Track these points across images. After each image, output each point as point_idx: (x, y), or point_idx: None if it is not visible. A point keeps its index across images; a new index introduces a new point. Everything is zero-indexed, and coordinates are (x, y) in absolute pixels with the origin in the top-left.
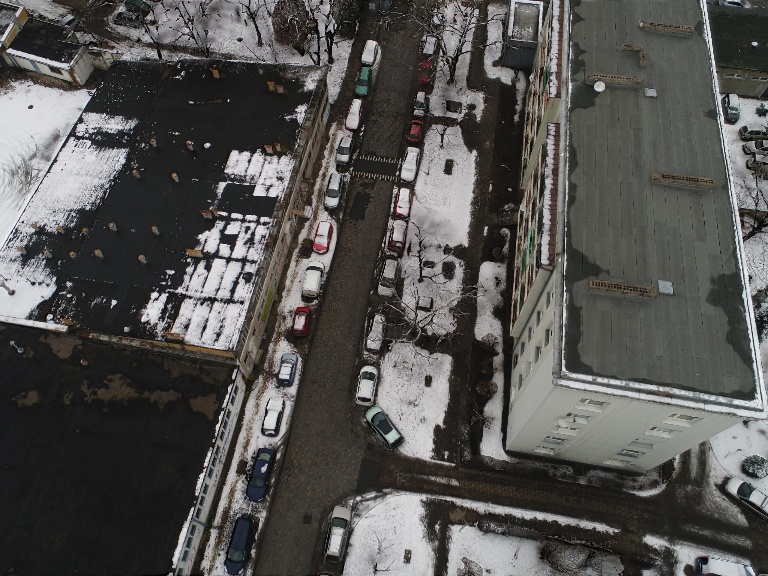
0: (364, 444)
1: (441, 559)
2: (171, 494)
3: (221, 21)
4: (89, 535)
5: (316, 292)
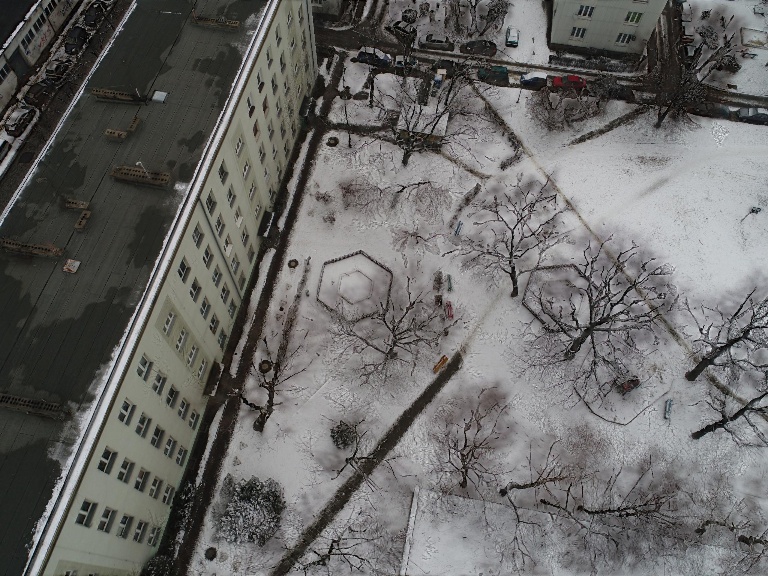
0: None
1: None
2: None
3: None
4: None
5: None
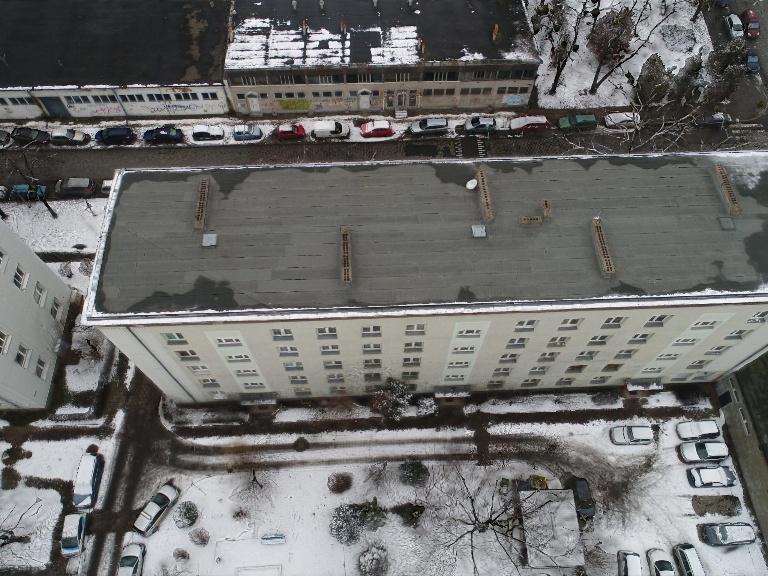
0: None
1: None
2: (127, 74)
3: (607, 5)
4: (100, 43)
5: (315, 132)
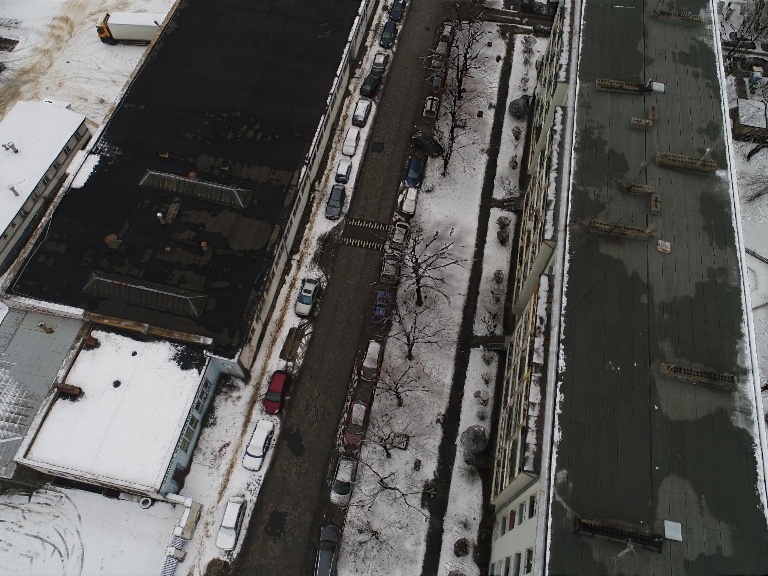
0: (460, 2)
1: (510, 46)
2: None
3: None
4: None
5: None
